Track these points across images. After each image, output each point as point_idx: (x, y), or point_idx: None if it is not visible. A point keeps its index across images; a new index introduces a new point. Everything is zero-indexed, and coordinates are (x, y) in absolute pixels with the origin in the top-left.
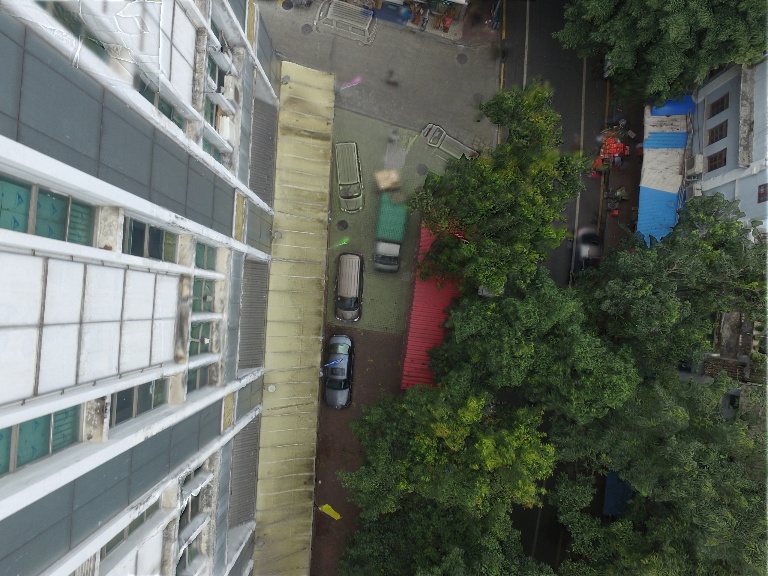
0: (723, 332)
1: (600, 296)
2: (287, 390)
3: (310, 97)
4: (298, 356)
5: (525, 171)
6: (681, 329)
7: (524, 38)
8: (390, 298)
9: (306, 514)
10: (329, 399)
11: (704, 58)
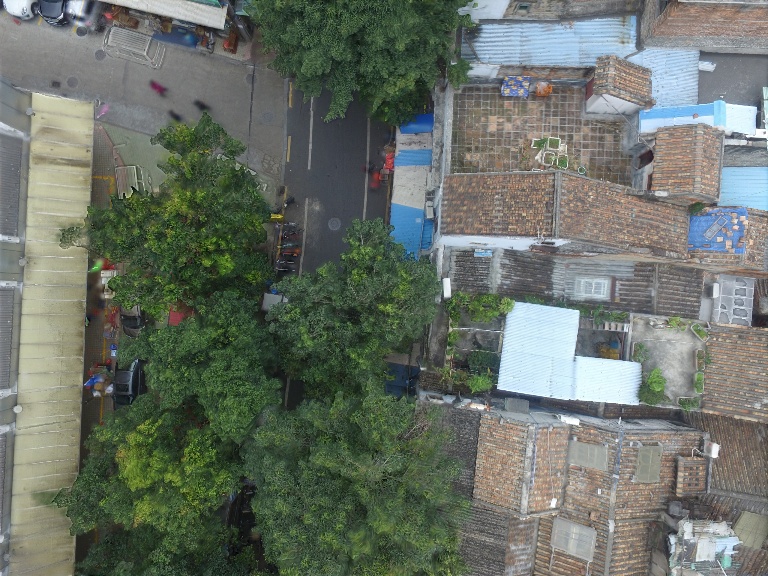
0: (431, 346)
1: (268, 319)
2: (45, 409)
3: (67, 126)
4: (58, 376)
5: None
6: (346, 349)
7: None
8: None
9: (69, 526)
10: None
11: (379, 86)
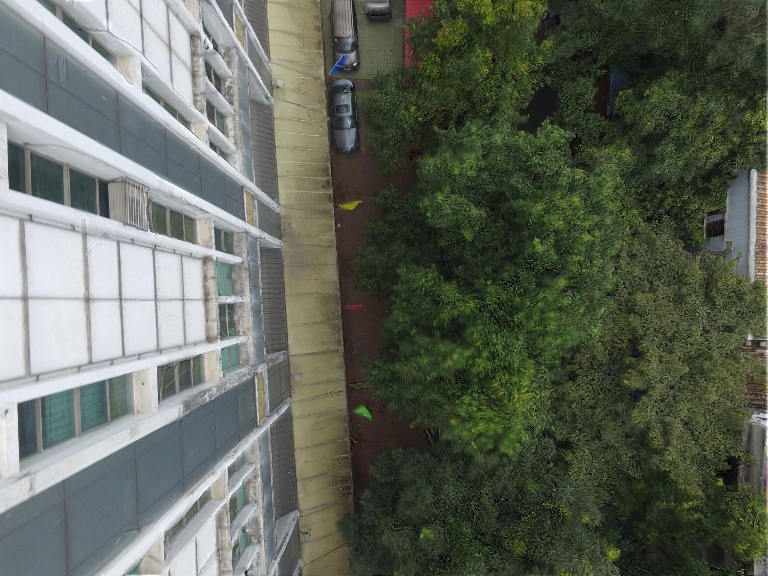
0: None
1: None
2: (295, 98)
3: None
4: (302, 68)
5: None
6: None
7: None
8: (385, 47)
9: (328, 215)
10: (338, 141)
11: None
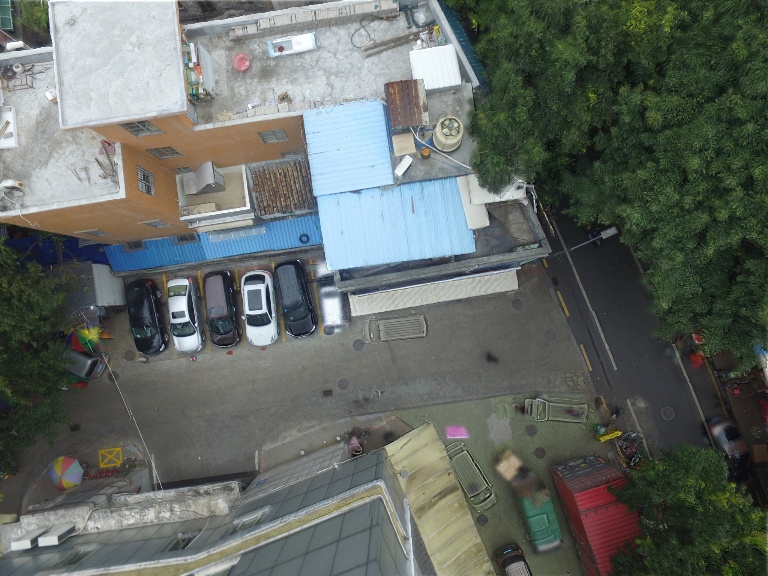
0: None
1: None
2: None
3: (422, 460)
4: None
5: (740, 562)
6: None
7: (566, 257)
8: (561, 570)
9: None
10: None
11: None
